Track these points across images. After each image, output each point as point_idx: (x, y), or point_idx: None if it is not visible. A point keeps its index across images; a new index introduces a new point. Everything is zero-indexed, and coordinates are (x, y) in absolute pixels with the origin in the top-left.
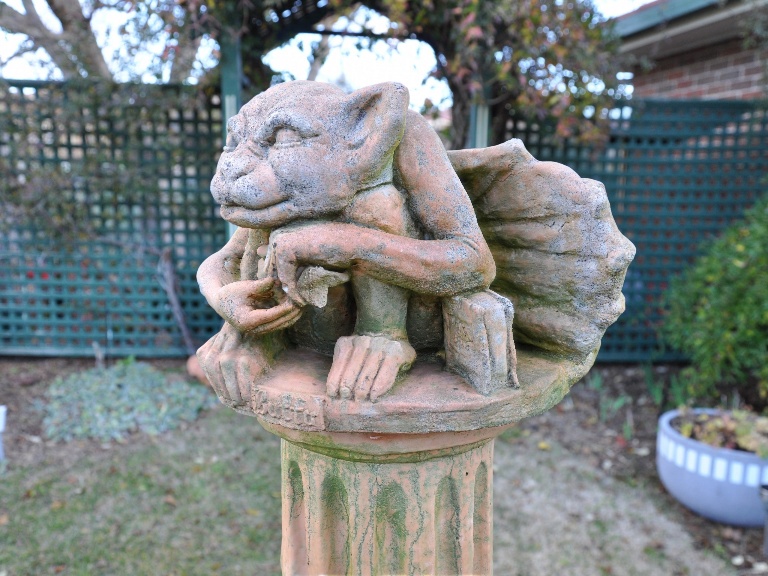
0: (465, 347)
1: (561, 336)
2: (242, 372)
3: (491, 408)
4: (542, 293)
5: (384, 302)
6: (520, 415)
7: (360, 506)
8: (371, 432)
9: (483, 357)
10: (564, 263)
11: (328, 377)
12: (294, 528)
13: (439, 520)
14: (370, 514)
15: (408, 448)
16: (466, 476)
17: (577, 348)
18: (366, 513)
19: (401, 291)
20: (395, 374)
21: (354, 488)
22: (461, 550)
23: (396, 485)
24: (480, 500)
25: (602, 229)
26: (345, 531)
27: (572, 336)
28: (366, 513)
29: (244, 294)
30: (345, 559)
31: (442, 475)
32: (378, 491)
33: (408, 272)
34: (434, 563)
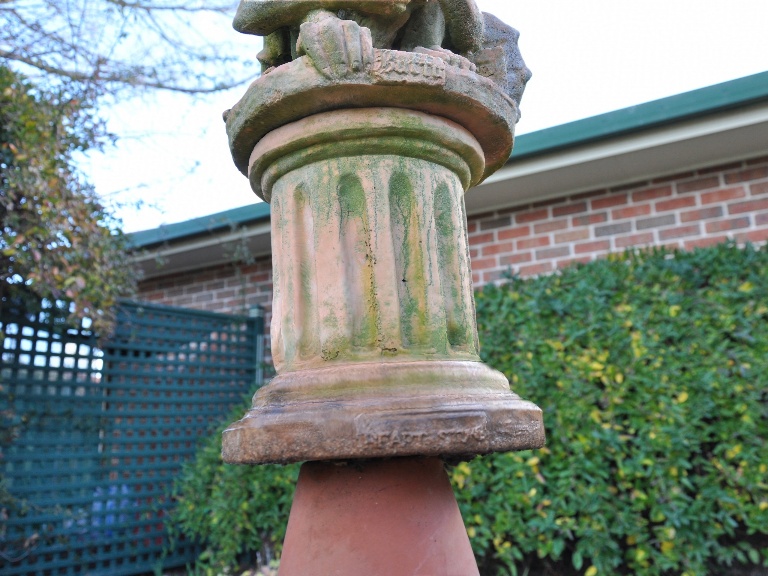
0: None
1: None
2: (367, 35)
3: None
4: None
5: (440, 32)
6: None
7: (426, 196)
8: (469, 99)
9: (505, 82)
10: None
11: (435, 54)
12: (343, 244)
13: None
14: (432, 205)
15: (466, 140)
16: None
17: None
18: (430, 203)
19: (444, 32)
20: None
21: (420, 181)
22: None
23: (445, 185)
24: None
25: (518, 51)
26: (402, 233)
27: None
28: (430, 203)
29: None
30: (403, 260)
31: (461, 192)
32: (436, 186)
33: (470, 3)
34: None
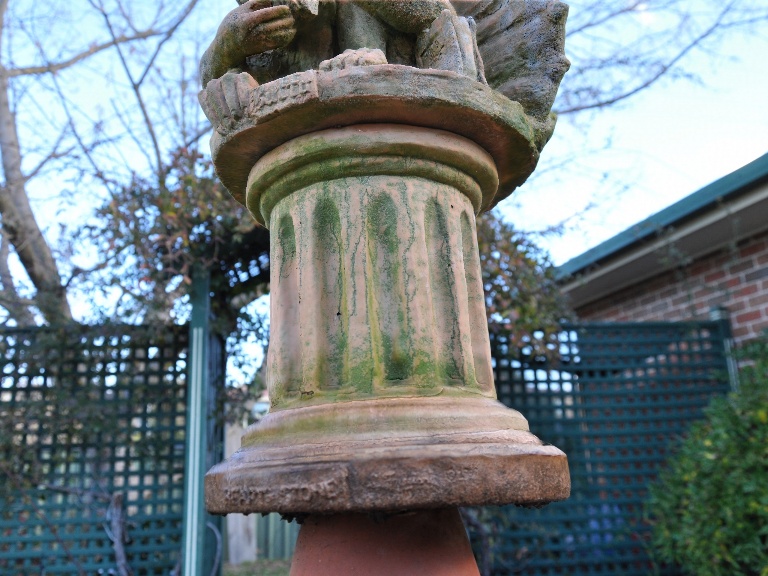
0: (438, 58)
1: (521, 93)
2: (242, 81)
3: (466, 83)
4: (500, 70)
5: (366, 30)
6: (493, 110)
7: (352, 217)
8: (361, 97)
9: (454, 49)
10: (514, 32)
11: None
12: (284, 288)
13: (429, 249)
14: (362, 224)
15: (395, 139)
16: (451, 208)
17: (536, 98)
18: (358, 223)
19: (380, 26)
20: (379, 61)
21: (345, 201)
22: (454, 276)
23: (385, 196)
24: (468, 258)
25: None
26: (337, 263)
27: (530, 89)
28: (358, 223)
29: (247, 6)
30: (338, 292)
31: (428, 195)
32: (368, 201)
33: None
34: (428, 277)
